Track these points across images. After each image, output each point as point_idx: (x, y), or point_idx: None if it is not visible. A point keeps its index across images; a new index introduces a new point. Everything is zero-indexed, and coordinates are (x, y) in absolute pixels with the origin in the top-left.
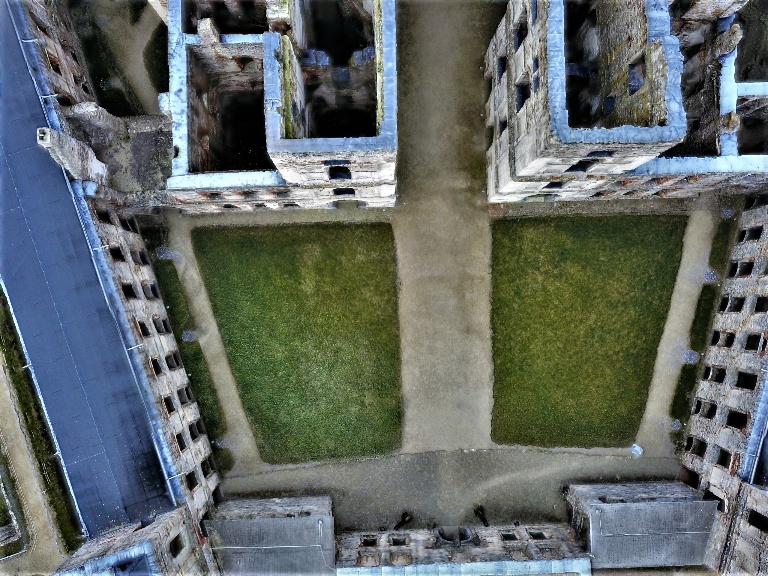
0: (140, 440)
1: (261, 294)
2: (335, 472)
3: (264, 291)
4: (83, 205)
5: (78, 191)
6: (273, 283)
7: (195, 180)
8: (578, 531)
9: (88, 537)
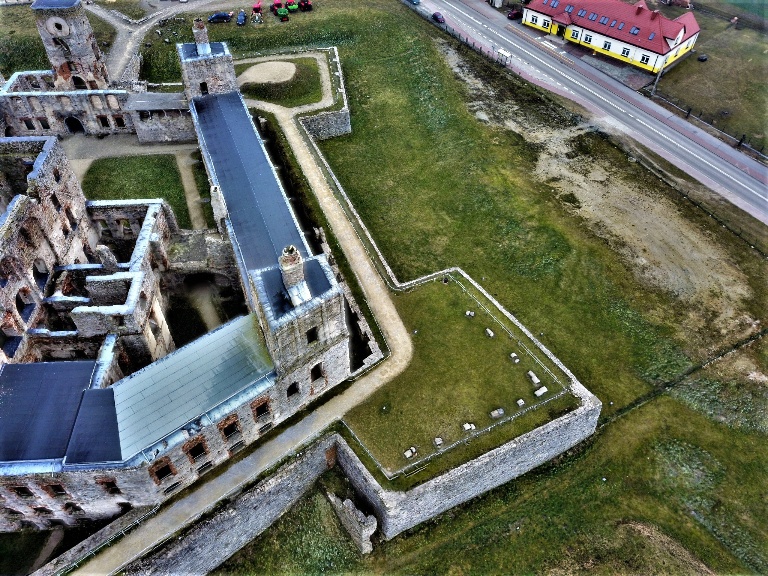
0: (204, 116)
1: None
2: (135, 152)
3: None
4: None
5: None
6: None
7: (144, 201)
8: (4, 118)
9: (238, 93)
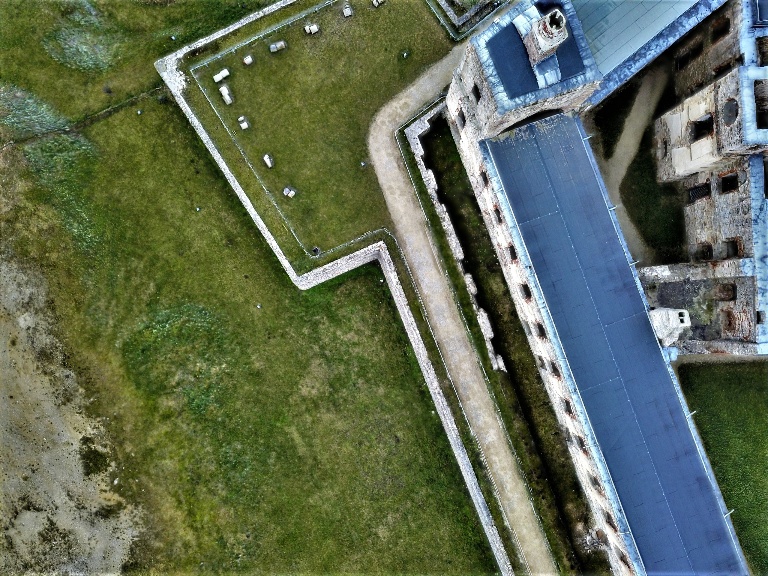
0: None
1: (753, 431)
2: None
3: (756, 428)
4: (671, 372)
5: (666, 358)
6: (764, 420)
7: None
8: None
9: None
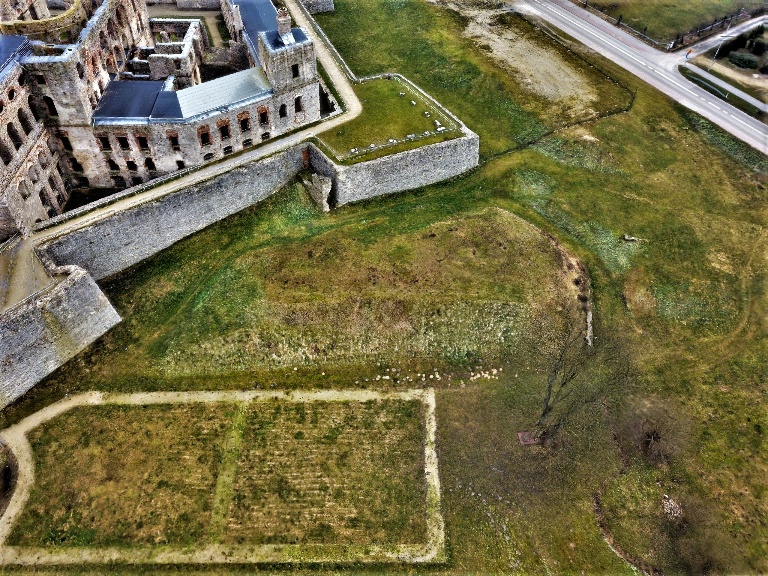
0: None
1: None
2: (175, 14)
3: None
4: None
5: None
6: None
7: None
8: None
9: None
